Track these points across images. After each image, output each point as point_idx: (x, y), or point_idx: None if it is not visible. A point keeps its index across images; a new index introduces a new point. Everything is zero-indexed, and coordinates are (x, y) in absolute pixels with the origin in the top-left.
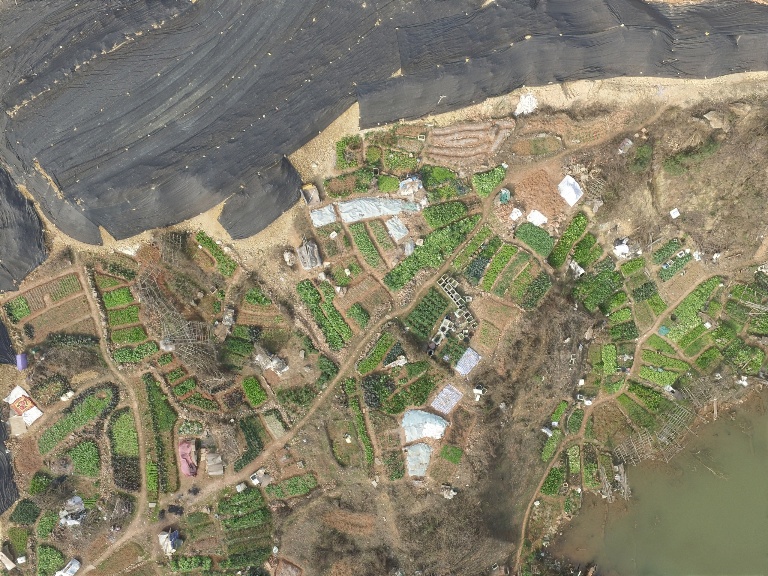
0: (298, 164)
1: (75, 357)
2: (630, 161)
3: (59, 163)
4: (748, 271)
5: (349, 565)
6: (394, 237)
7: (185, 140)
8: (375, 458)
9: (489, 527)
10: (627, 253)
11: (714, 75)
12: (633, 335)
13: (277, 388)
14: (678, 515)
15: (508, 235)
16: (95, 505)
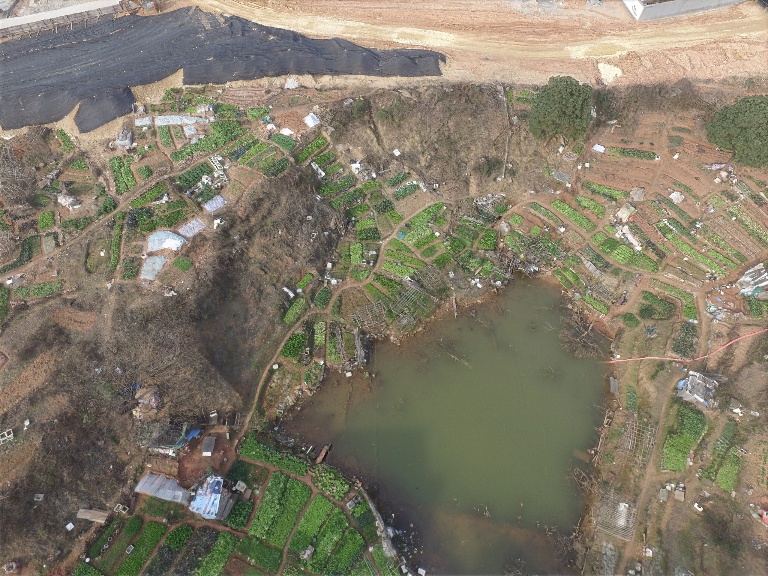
0: (137, 94)
1: None
2: None
3: None
4: (467, 202)
5: (55, 357)
6: (186, 134)
7: None
8: None
9: (208, 350)
10: (359, 169)
11: (404, 75)
12: (376, 236)
13: (65, 219)
14: (423, 400)
15: (265, 139)
16: None
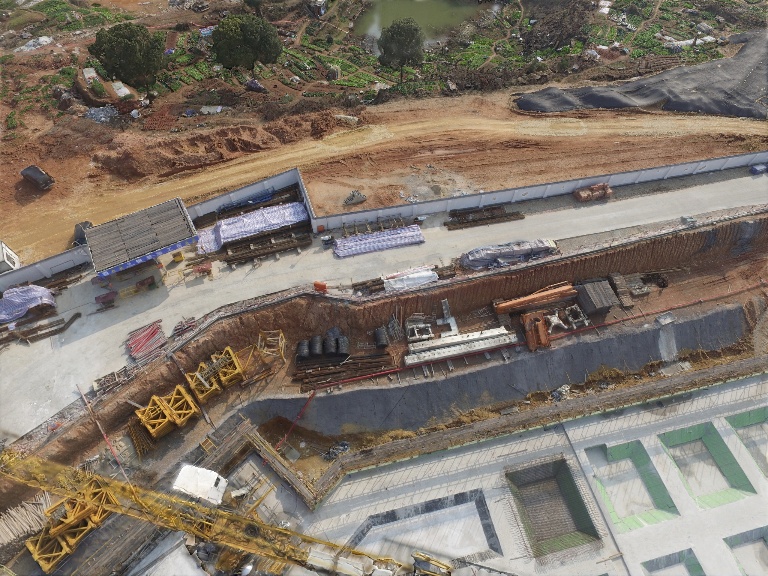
0: None
1: None
2: None
3: None
4: None
5: None
6: None
7: None
8: None
9: None
10: None
11: None
12: None
13: (680, 7)
14: None
15: None
16: None
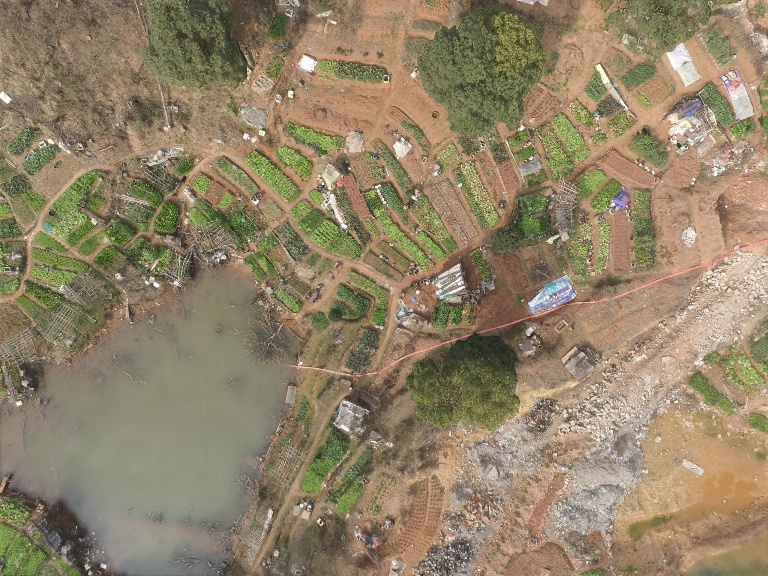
0: None
1: None
2: None
3: None
4: (132, 165)
5: None
6: None
7: None
8: None
9: None
10: None
11: None
12: (15, 232)
13: None
14: (99, 422)
15: None
16: None
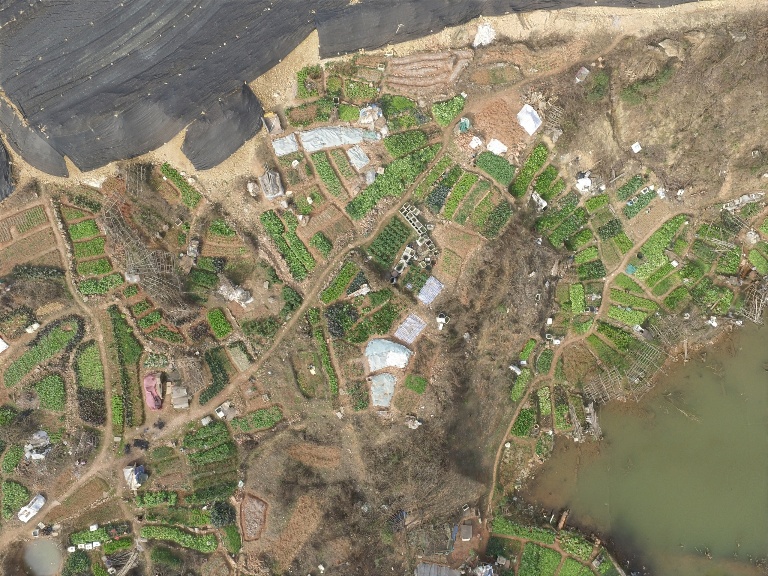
0: (259, 92)
1: (41, 289)
2: (588, 91)
3: (24, 92)
4: (713, 209)
5: (315, 499)
6: (355, 166)
7: (148, 68)
8: (339, 389)
9: (457, 463)
10: (590, 186)
11: (668, 4)
12: (600, 274)
13: (242, 320)
14: (651, 458)
15: (469, 164)
16: (60, 439)
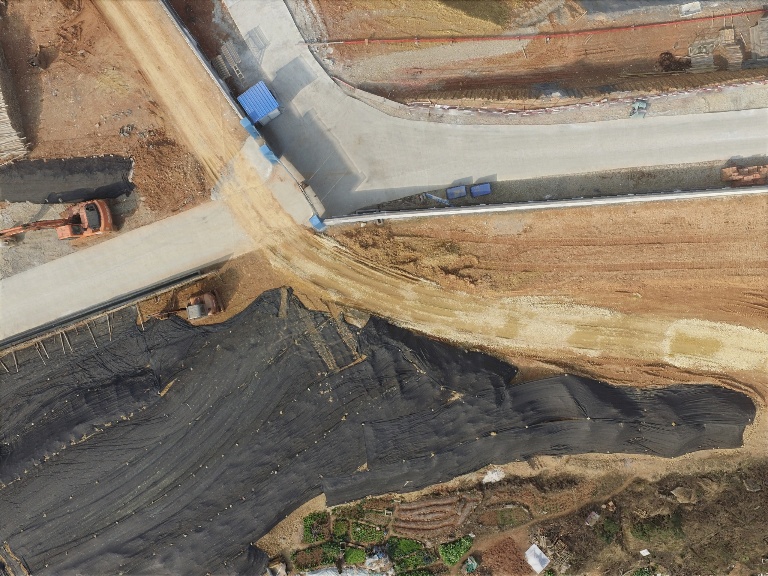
0: (265, 544)
1: None
2: (598, 526)
3: (29, 548)
4: None
5: None
6: None
7: (153, 527)
8: None
9: None
10: None
11: (681, 454)
12: None
13: None
14: None
15: None
16: None
